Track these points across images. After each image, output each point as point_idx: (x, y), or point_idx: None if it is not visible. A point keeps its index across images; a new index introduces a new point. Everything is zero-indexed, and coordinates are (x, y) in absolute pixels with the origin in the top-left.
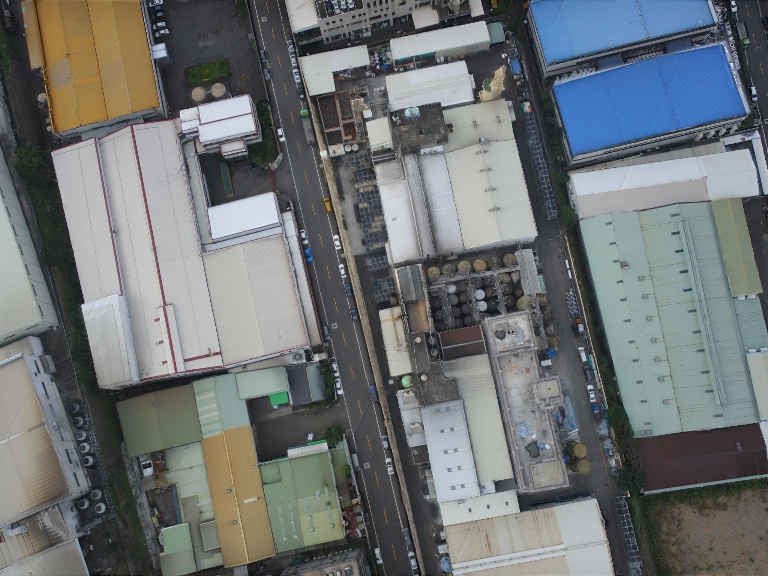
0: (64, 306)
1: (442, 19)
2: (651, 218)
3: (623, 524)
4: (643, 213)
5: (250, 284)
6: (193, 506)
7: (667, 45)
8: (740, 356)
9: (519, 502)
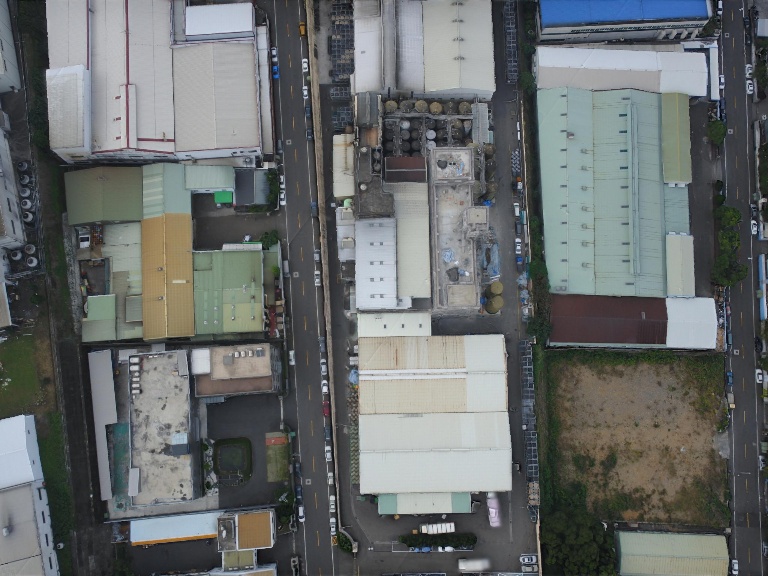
0: (29, 72)
1: None
2: (603, 99)
3: (524, 364)
4: (597, 93)
5: (214, 81)
6: (123, 280)
7: None
8: (660, 236)
9: (432, 326)
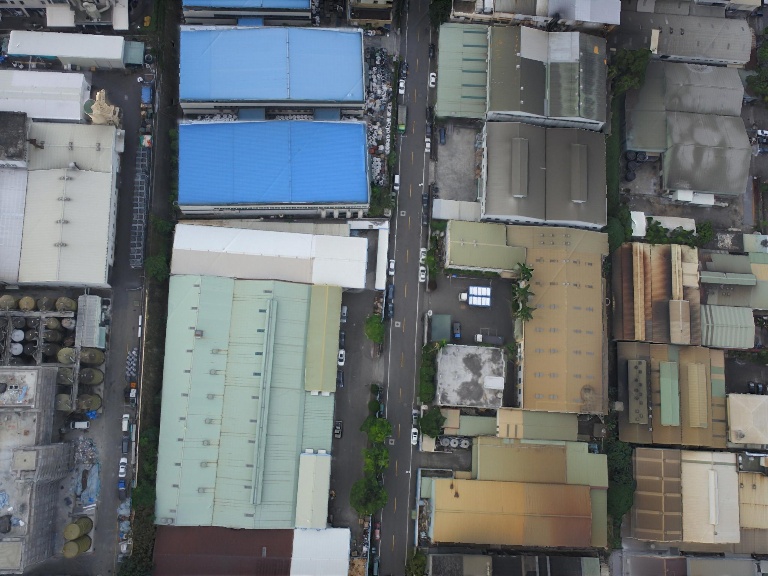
0: None
1: (78, 23)
2: (245, 289)
3: None
4: (239, 282)
5: None
6: None
7: (315, 111)
8: (294, 455)
9: None
